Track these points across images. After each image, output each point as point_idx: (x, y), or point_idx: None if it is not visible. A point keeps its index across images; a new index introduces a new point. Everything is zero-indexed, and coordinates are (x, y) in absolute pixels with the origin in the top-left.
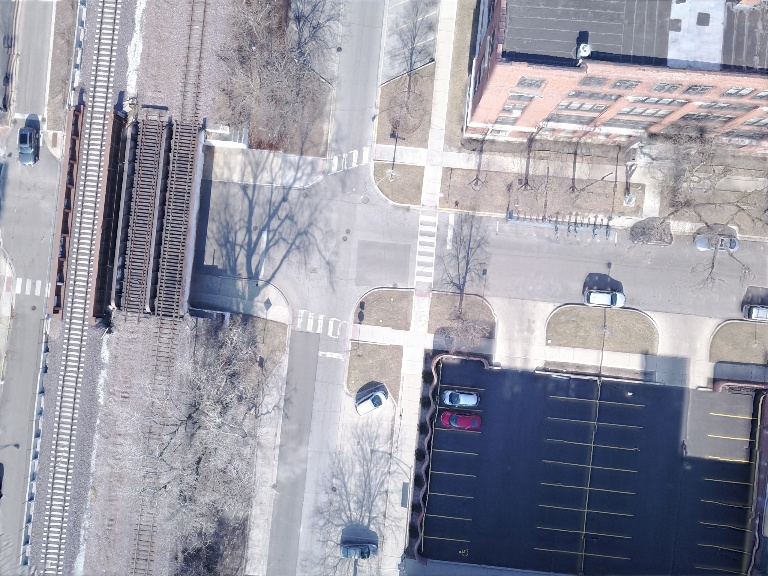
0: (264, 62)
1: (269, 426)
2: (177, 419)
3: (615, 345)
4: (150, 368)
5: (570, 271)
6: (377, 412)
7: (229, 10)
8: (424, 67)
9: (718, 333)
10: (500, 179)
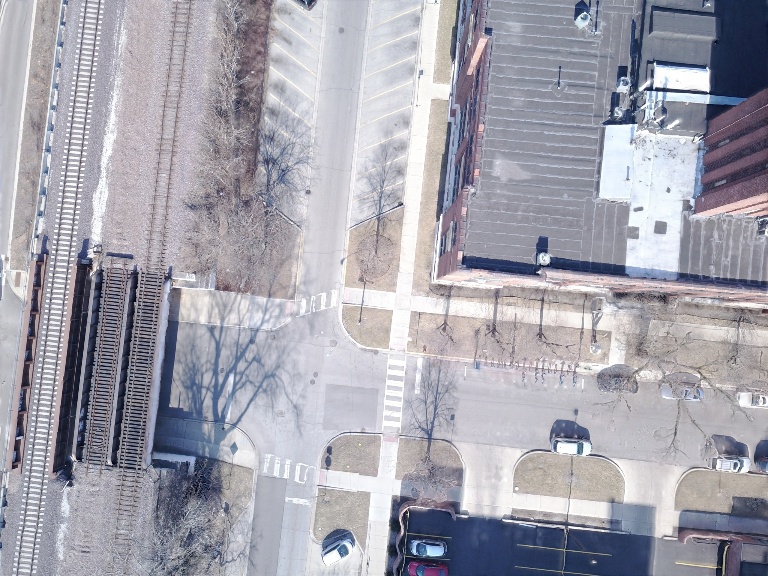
0: (230, 220)
1: (234, 574)
2: (139, 575)
3: (582, 493)
4: (112, 522)
5: (537, 417)
6: (344, 560)
7: (196, 158)
8: (393, 211)
9: (683, 481)
10: (468, 324)
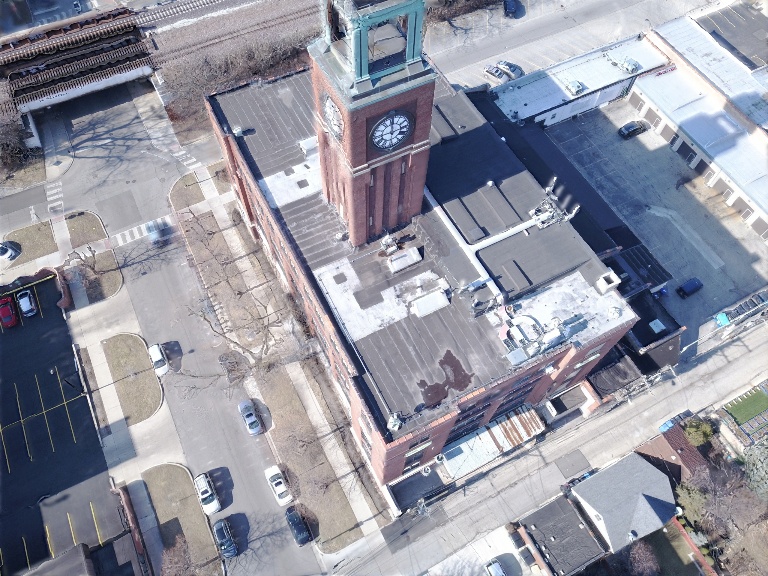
0: None
1: None
2: None
3: (123, 390)
4: None
5: None
6: None
7: (238, 50)
8: None
9: (172, 466)
10: (221, 246)
